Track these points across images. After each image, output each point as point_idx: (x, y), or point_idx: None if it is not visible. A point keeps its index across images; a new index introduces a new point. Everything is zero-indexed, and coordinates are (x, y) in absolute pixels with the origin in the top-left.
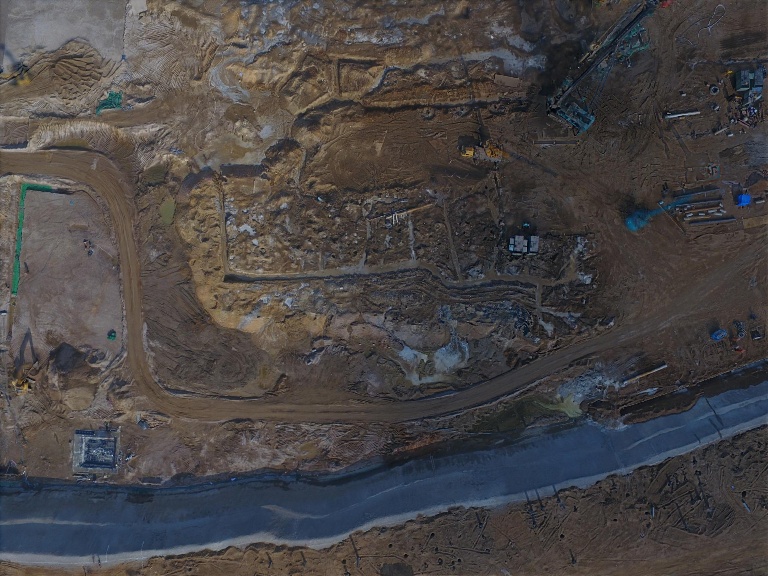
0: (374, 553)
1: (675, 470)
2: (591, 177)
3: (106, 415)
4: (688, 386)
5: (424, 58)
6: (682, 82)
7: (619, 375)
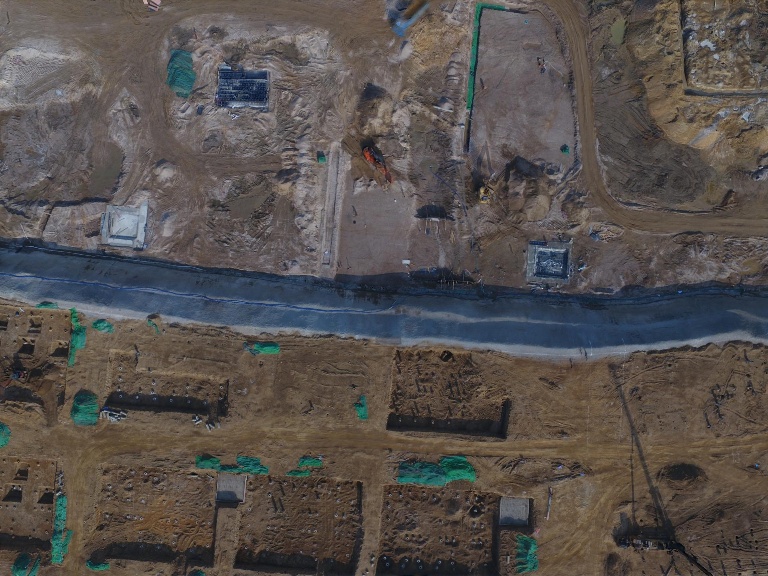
0: None
1: None
2: None
3: (560, 226)
4: None
5: None
6: None
7: None
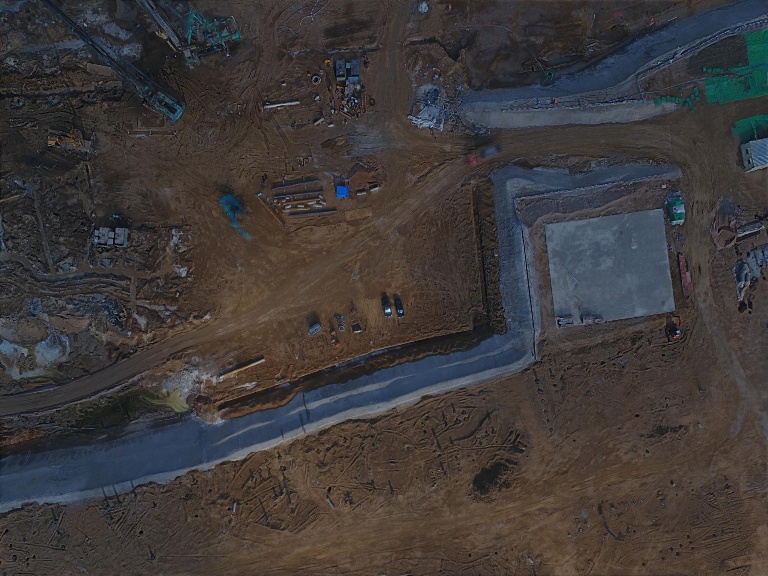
0: None
1: (259, 465)
2: (188, 168)
3: None
4: (289, 380)
5: (14, 46)
6: (284, 71)
7: (217, 369)
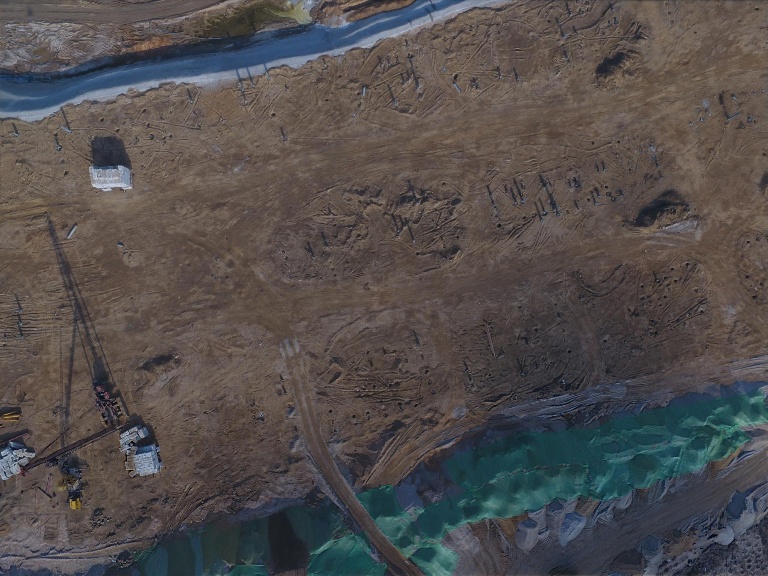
0: (86, 126)
1: (387, 52)
2: None
3: None
4: None
5: None
6: None
7: None
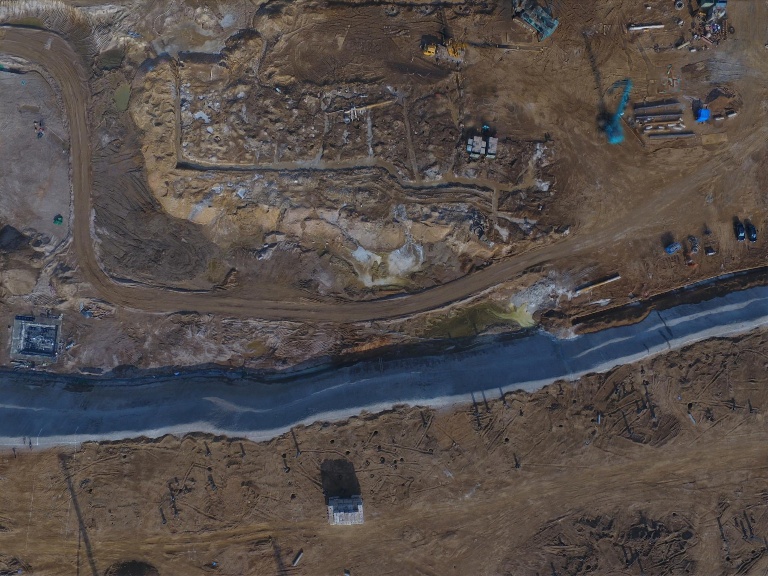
0: (315, 448)
1: (623, 378)
2: (553, 84)
3: (48, 301)
4: (641, 299)
5: None
6: None
7: (572, 284)
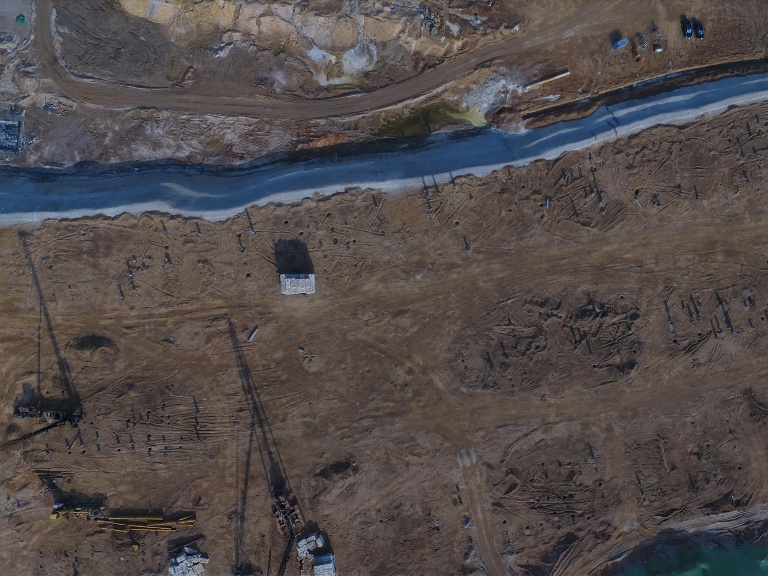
0: (269, 228)
1: (571, 165)
2: None
3: (11, 97)
4: (590, 96)
5: None
6: None
7: (523, 80)
